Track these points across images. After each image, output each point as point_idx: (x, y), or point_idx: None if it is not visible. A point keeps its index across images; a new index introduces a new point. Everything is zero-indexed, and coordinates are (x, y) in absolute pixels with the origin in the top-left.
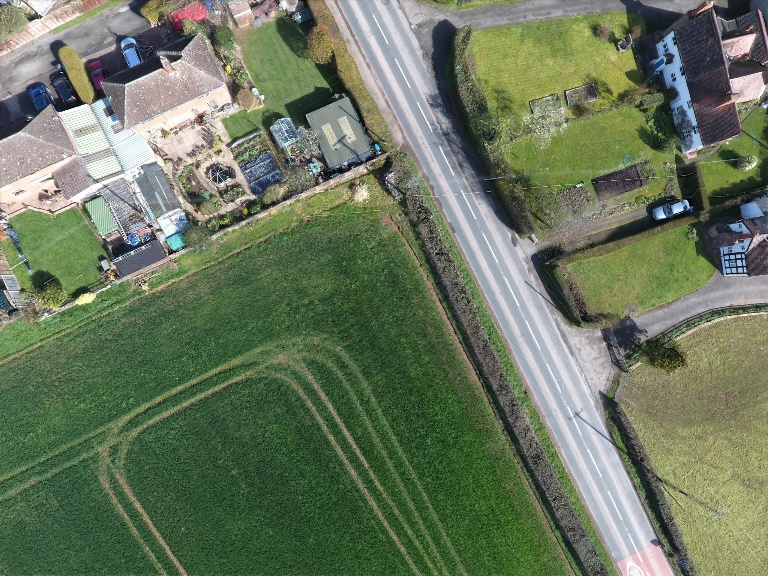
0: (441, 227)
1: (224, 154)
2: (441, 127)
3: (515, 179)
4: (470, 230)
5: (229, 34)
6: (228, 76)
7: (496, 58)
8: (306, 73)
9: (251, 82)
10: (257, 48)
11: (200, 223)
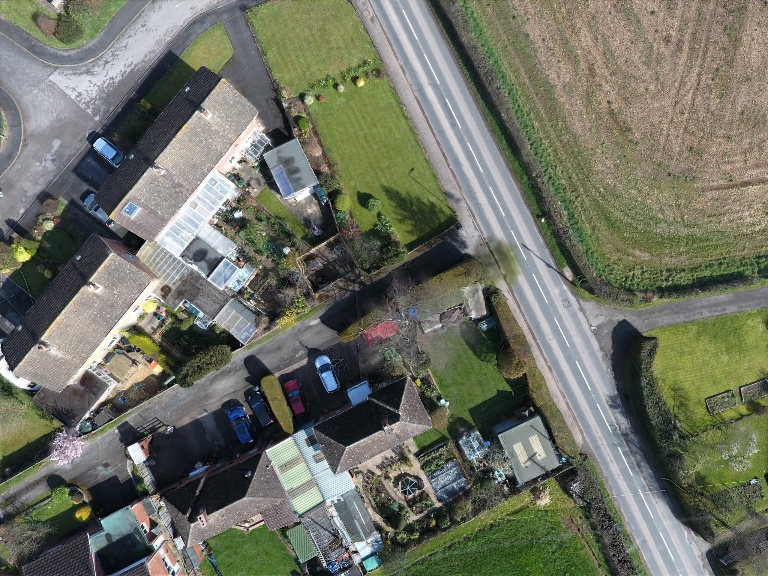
0: (620, 528)
1: (414, 467)
2: (620, 428)
3: (700, 493)
4: (647, 529)
5: (429, 365)
6: (416, 387)
7: (673, 356)
8: (489, 377)
9: (438, 391)
10: (442, 353)
11: (389, 534)
